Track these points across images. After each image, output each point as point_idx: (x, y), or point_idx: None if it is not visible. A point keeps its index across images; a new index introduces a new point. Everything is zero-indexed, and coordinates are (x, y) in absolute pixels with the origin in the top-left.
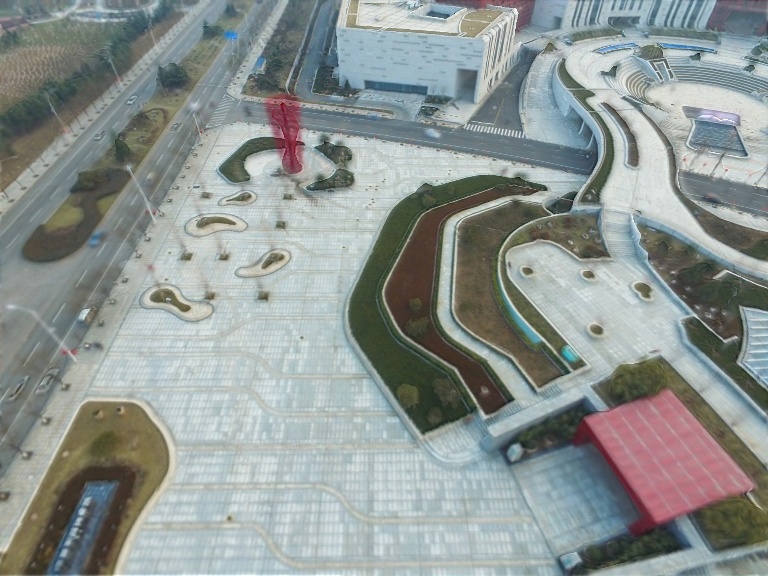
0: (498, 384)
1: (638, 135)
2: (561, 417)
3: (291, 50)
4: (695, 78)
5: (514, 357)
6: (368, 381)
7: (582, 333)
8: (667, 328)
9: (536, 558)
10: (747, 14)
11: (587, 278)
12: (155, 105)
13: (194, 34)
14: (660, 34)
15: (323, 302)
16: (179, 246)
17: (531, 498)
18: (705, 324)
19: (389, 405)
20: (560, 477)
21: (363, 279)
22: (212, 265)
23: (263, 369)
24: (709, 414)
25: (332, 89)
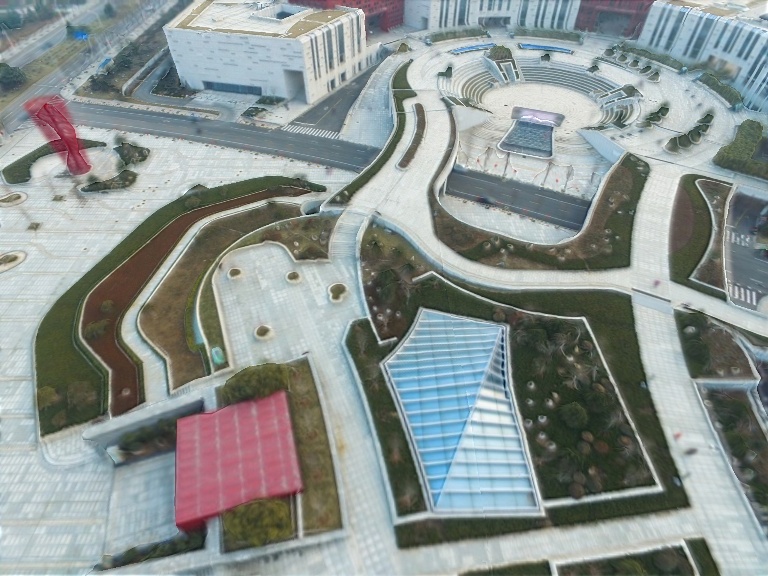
0: (140, 386)
1: (429, 136)
2: (172, 419)
3: (150, 50)
4: (542, 79)
5: (169, 359)
6: (26, 383)
7: (249, 335)
8: (337, 329)
9: (84, 560)
10: (616, 15)
11: (289, 279)
12: None
13: (61, 34)
14: (525, 35)
15: (30, 304)
16: None
17: (116, 500)
18: (373, 325)
19: (33, 407)
20: (158, 479)
21: (81, 281)
22: None
23: None
24: (315, 416)
25: (171, 90)
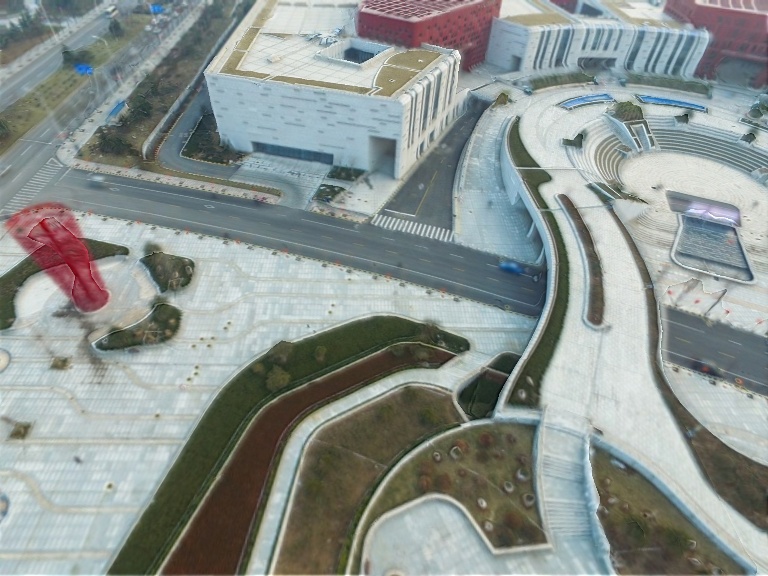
0: None
1: (605, 258)
2: None
3: (174, 88)
4: (681, 146)
5: None
6: None
7: None
8: None
9: None
10: (742, 61)
11: None
12: None
13: (55, 60)
14: (639, 82)
15: None
16: None
17: None
18: None
19: None
20: None
21: None
22: None
23: None
24: None
25: (208, 151)
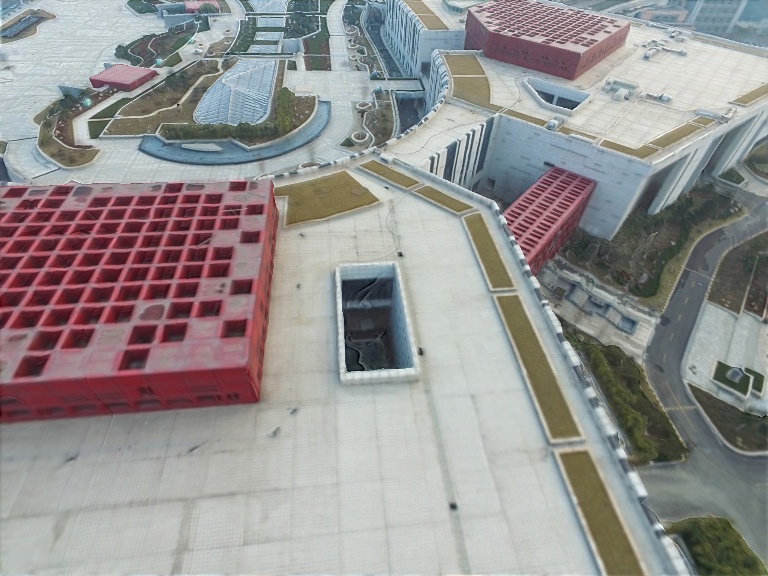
0: None
1: None
2: None
3: None
4: None
5: None
6: None
7: None
8: None
9: (160, 26)
10: None
11: None
12: None
13: None
14: None
15: (120, 1)
16: None
17: None
18: None
19: (133, 13)
20: None
21: None
22: None
23: (92, 8)
24: None
25: None
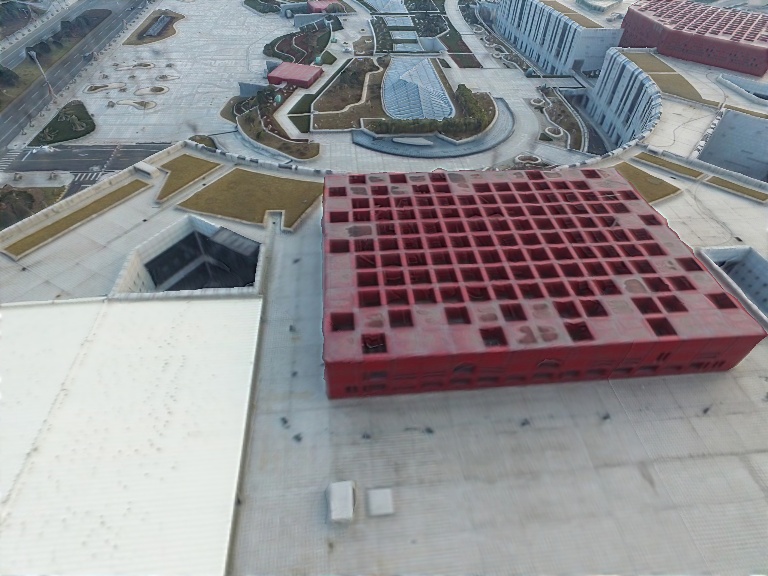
0: None
1: None
2: (303, 6)
3: None
4: None
5: None
6: None
7: None
8: None
9: None
10: None
11: None
12: None
13: None
14: None
15: (235, 1)
16: None
17: None
18: None
19: None
20: None
21: None
22: None
23: (213, 8)
24: None
25: None
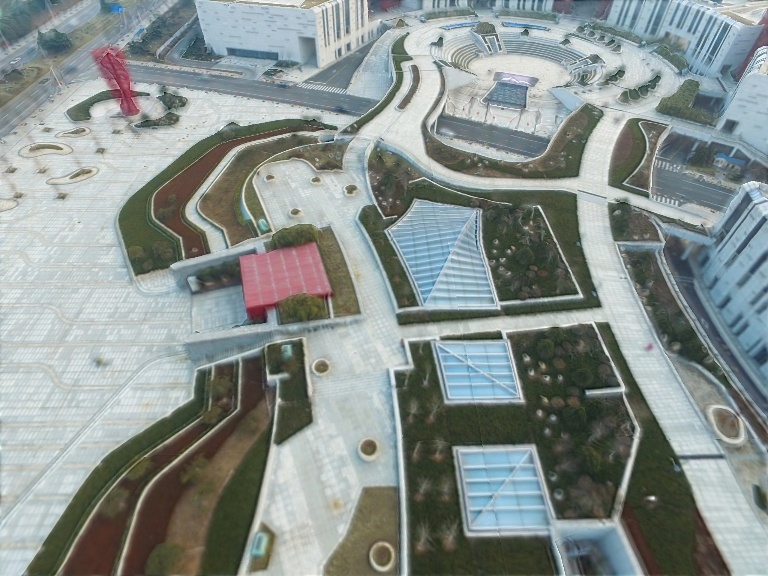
0: (205, 246)
1: (423, 88)
2: (233, 261)
3: (177, 24)
4: (522, 51)
5: (225, 229)
6: (116, 248)
7: (285, 215)
8: (351, 212)
9: (179, 342)
10: None
11: (313, 182)
12: (33, 64)
13: (94, 10)
14: (508, 15)
15: (108, 201)
16: (8, 163)
17: (196, 312)
18: (379, 209)
19: (124, 262)
20: (225, 301)
21: (146, 186)
22: (30, 176)
23: (39, 241)
24: (338, 258)
25: (198, 55)
